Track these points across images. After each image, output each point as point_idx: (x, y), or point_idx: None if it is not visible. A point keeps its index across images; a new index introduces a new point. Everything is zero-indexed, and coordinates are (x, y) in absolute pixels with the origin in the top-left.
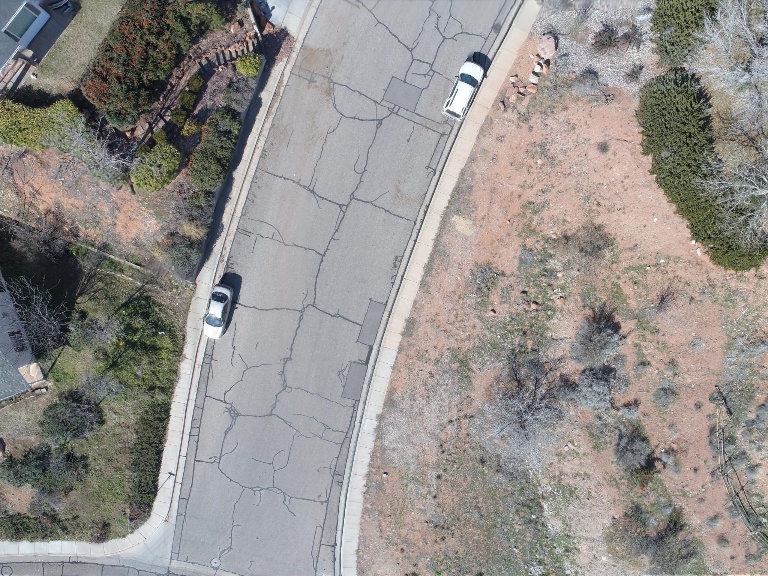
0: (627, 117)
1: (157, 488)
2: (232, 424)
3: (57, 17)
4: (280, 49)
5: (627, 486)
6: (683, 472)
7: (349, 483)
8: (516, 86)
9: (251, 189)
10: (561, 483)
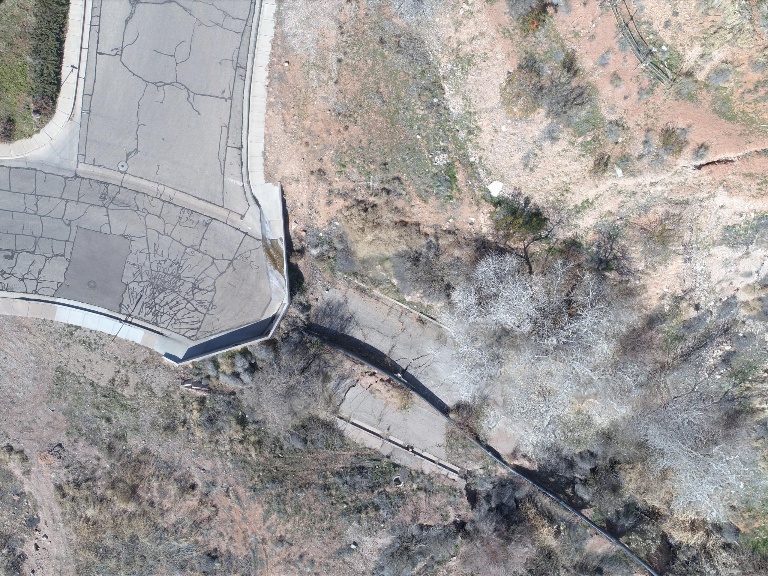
0: None
1: (60, 83)
2: (132, 12)
3: None
4: None
5: (520, 35)
6: (573, 10)
7: (252, 77)
8: None
9: None
10: (459, 55)
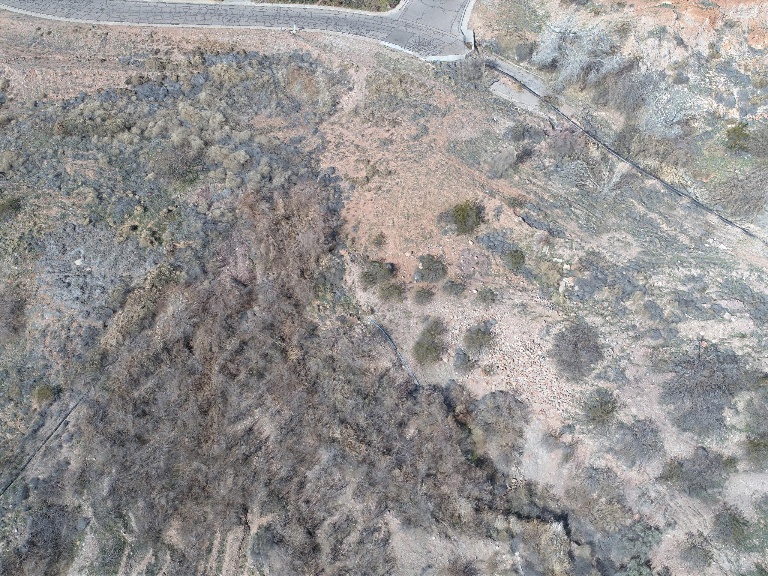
0: None
1: (399, 3)
2: None
3: None
4: None
5: None
6: None
7: None
8: None
9: None
10: None
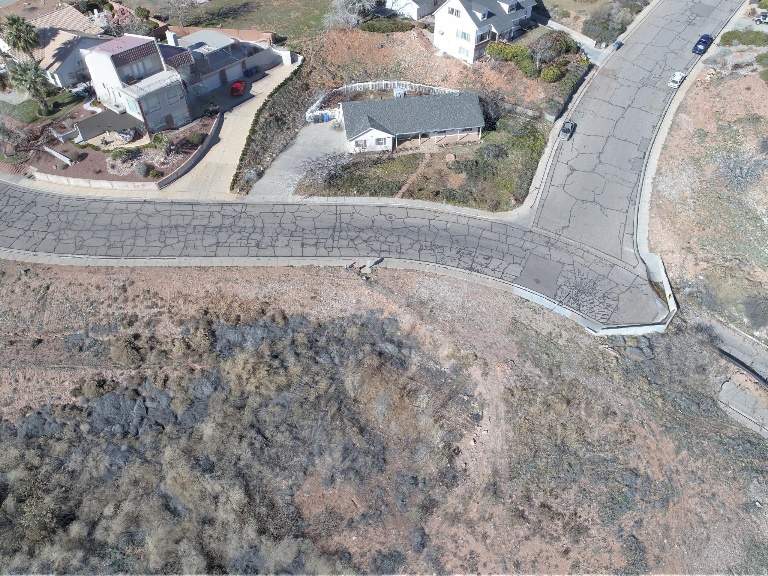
0: (756, 79)
1: (528, 193)
2: (571, 173)
3: (522, 31)
4: (593, 67)
5: None
6: None
7: (639, 205)
8: (700, 81)
9: (581, 100)
10: None
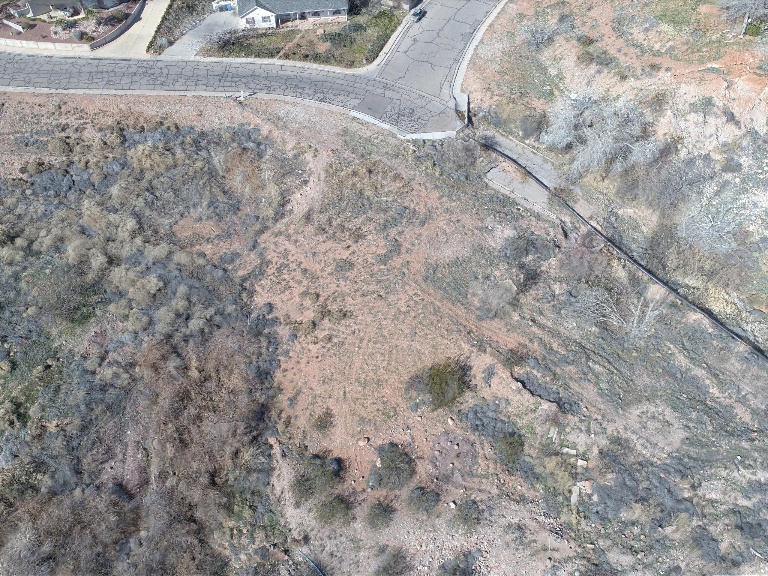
0: None
1: (378, 56)
2: (414, 43)
3: None
4: None
5: (582, 47)
6: None
7: None
8: None
9: None
10: None
